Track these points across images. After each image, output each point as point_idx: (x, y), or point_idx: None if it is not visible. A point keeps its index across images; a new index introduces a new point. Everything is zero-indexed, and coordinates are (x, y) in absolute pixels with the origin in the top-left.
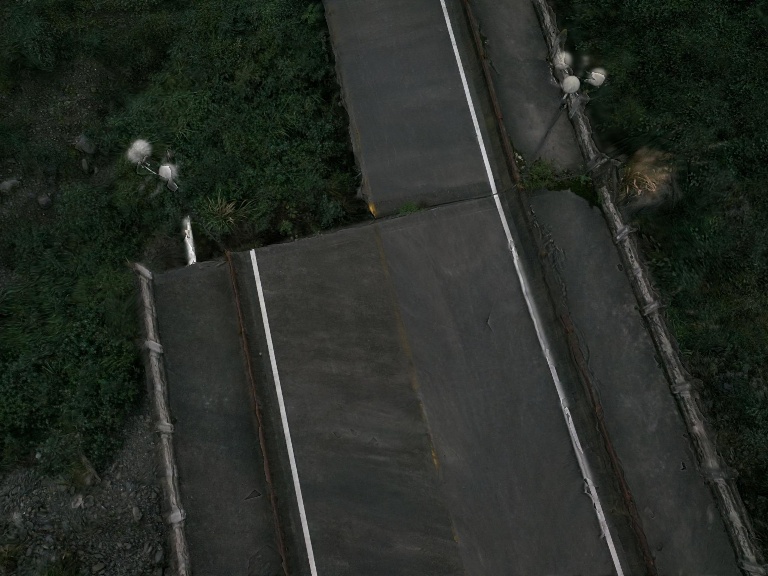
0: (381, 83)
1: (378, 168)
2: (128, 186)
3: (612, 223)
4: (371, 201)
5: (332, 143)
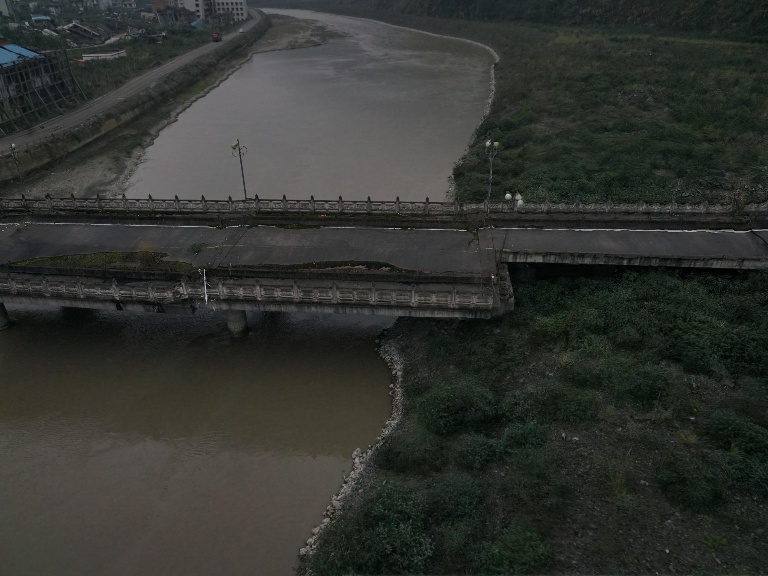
0: (693, 247)
1: (746, 253)
2: (764, 357)
3: (760, 209)
4: (767, 256)
5: (719, 278)
